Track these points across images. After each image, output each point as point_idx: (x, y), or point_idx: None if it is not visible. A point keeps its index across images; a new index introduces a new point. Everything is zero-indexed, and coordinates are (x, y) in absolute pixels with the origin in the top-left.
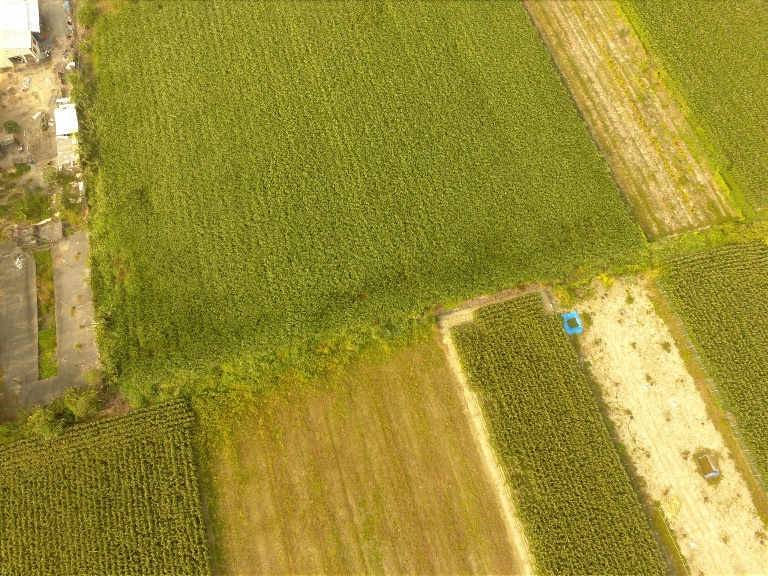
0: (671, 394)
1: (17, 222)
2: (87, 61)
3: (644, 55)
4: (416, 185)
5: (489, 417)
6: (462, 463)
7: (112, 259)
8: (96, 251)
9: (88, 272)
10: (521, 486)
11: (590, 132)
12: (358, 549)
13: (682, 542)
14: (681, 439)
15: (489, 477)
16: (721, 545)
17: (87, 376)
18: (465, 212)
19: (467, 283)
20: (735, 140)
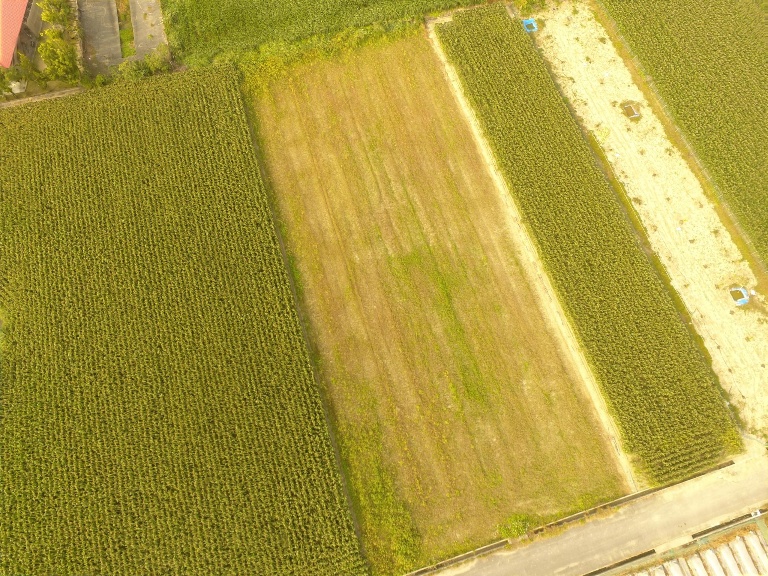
0: (605, 68)
1: None
2: None
3: None
4: None
5: (463, 75)
6: (443, 107)
7: None
8: None
9: None
10: (487, 114)
11: None
12: (365, 155)
13: (609, 154)
14: (611, 95)
15: (464, 116)
16: (639, 156)
17: (160, 45)
18: None
19: None
20: None
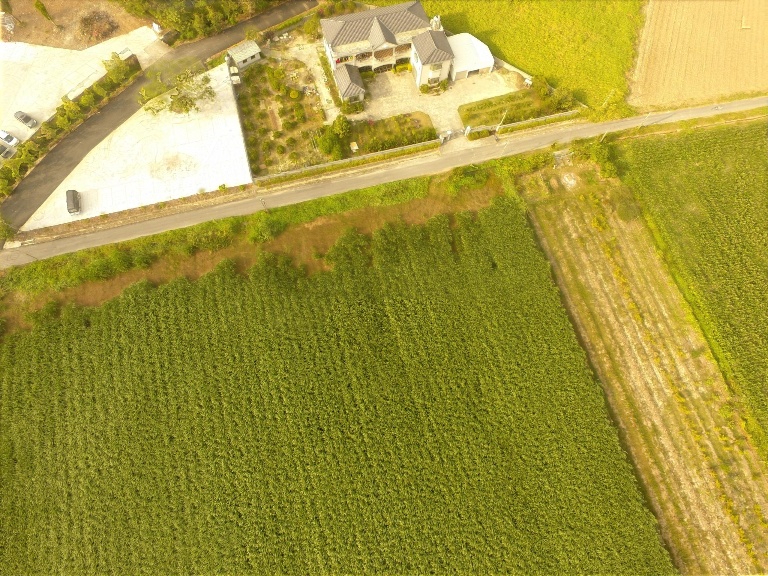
0: None
1: None
2: None
3: (726, 392)
4: None
5: None
6: None
7: None
8: None
9: None
10: None
11: (659, 524)
12: None
13: None
14: None
15: None
16: None
17: None
18: None
19: None
20: None
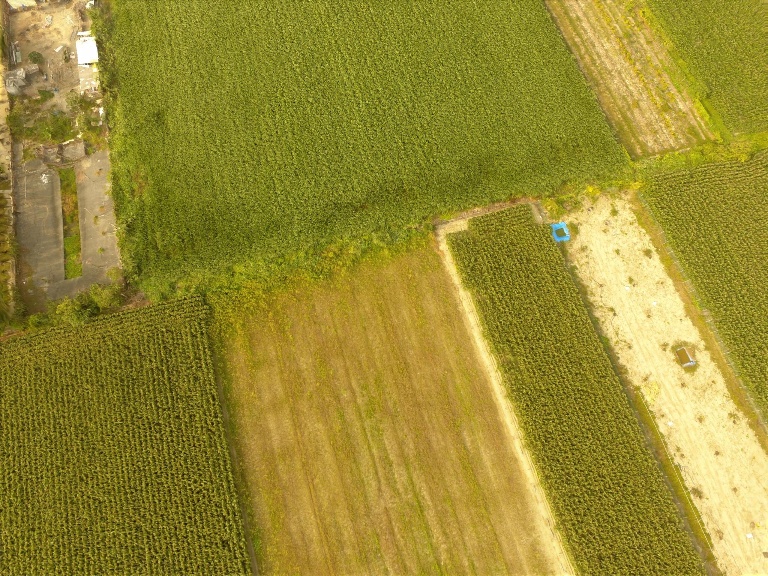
0: (652, 294)
1: (42, 142)
2: (105, 1)
3: None
4: (414, 109)
5: (482, 311)
6: (457, 353)
7: (131, 174)
8: (116, 167)
9: (109, 186)
10: (511, 370)
11: (578, 65)
12: (361, 425)
13: (660, 421)
14: (661, 333)
15: (482, 365)
16: (696, 424)
17: (110, 272)
18: (460, 133)
19: (462, 195)
20: (715, 71)
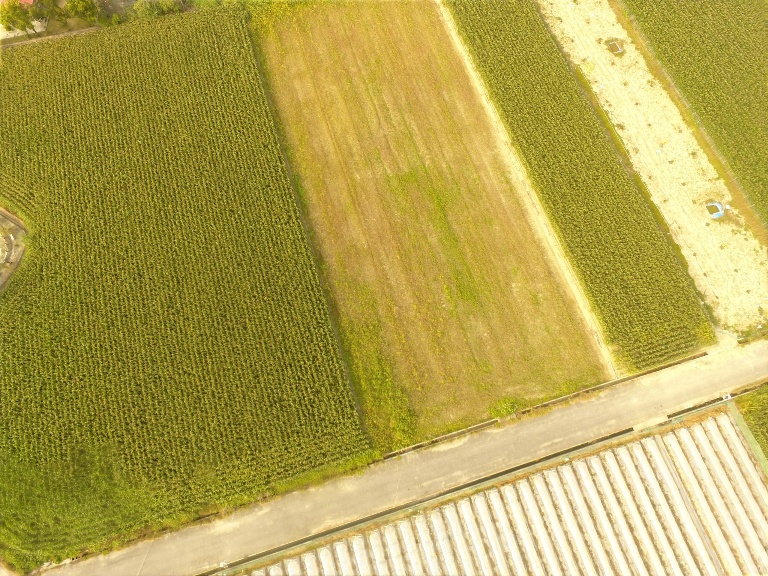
0: (591, 9)
1: None
2: None
3: None
4: None
5: (457, 15)
6: (438, 44)
7: None
8: None
9: None
10: (479, 49)
11: None
12: (365, 87)
13: (594, 85)
14: (597, 33)
15: (458, 52)
16: (622, 87)
17: None
18: None
19: None
20: None
